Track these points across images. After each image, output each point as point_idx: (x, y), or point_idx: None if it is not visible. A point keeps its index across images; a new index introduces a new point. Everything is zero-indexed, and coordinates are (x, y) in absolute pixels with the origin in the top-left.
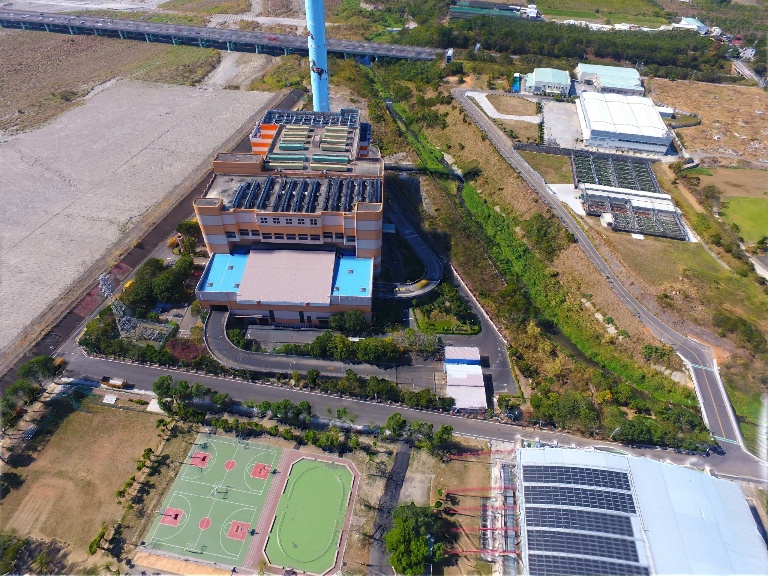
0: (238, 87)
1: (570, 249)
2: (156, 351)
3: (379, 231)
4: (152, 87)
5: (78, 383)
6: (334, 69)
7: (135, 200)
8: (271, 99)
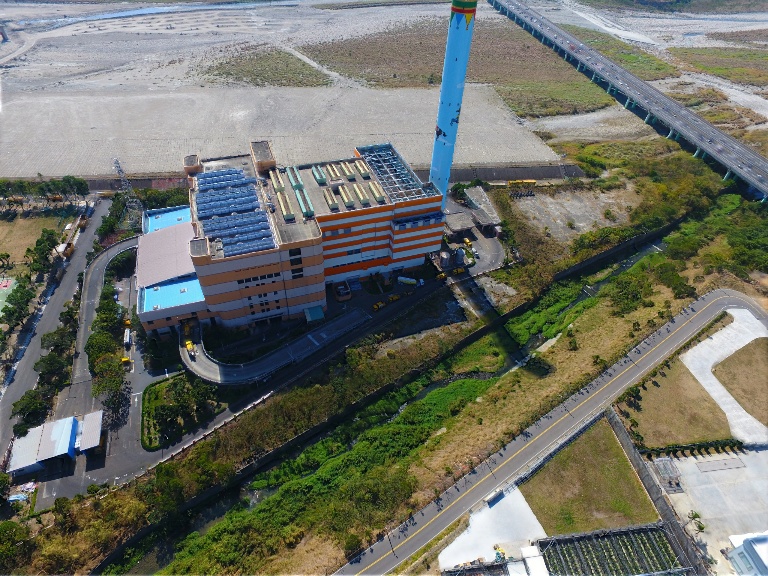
0: (550, 137)
1: (333, 551)
2: (106, 226)
3: (200, 277)
4: (490, 101)
5: (88, 210)
6: (678, 177)
7: (304, 157)
8: (539, 161)
